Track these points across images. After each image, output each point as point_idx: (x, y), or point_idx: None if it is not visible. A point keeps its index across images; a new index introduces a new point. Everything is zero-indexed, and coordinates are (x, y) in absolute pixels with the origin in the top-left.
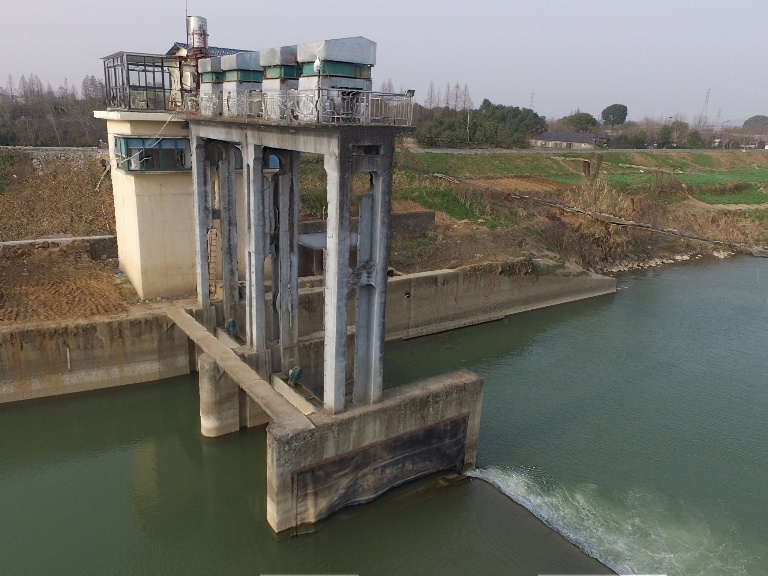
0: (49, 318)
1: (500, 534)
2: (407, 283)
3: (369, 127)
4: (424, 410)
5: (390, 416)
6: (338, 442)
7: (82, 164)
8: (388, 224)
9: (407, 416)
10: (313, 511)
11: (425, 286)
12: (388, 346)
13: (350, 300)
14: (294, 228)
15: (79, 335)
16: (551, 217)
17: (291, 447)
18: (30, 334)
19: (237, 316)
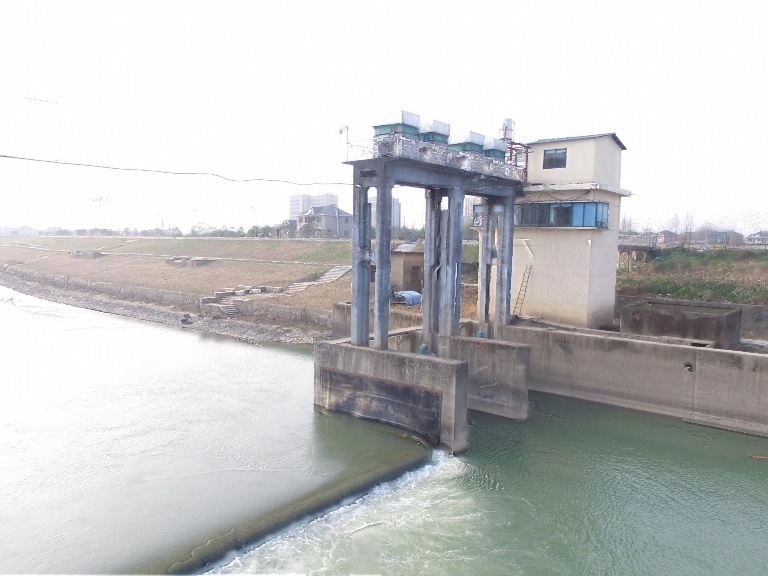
0: None
1: (364, 460)
2: (690, 353)
3: (369, 160)
4: (402, 368)
5: (377, 360)
6: (345, 361)
7: None
8: (382, 221)
9: (389, 366)
10: (328, 401)
11: (720, 364)
12: (659, 420)
13: (610, 352)
14: (450, 247)
15: (416, 322)
16: None
17: (321, 350)
18: (398, 315)
19: (503, 336)
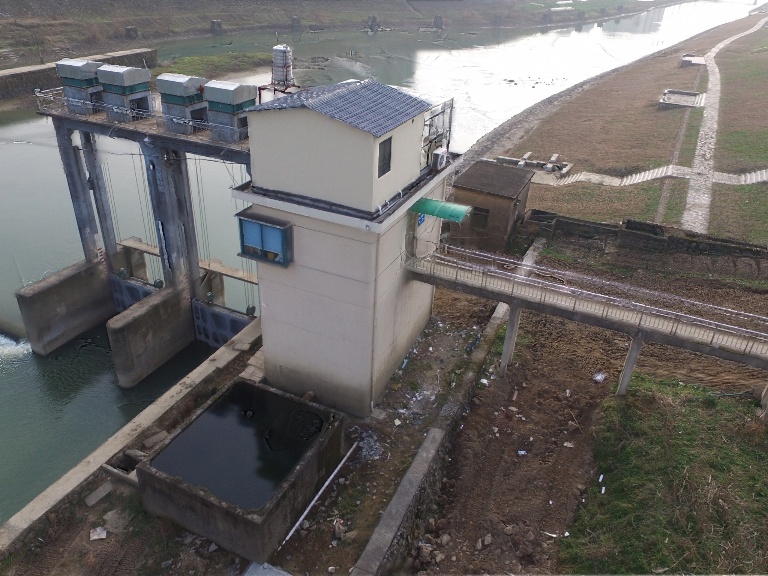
0: None
1: None
2: None
3: None
4: None
5: None
6: None
7: None
8: None
9: None
10: None
11: None
12: None
13: None
14: None
15: None
16: None
17: None
18: None
19: None
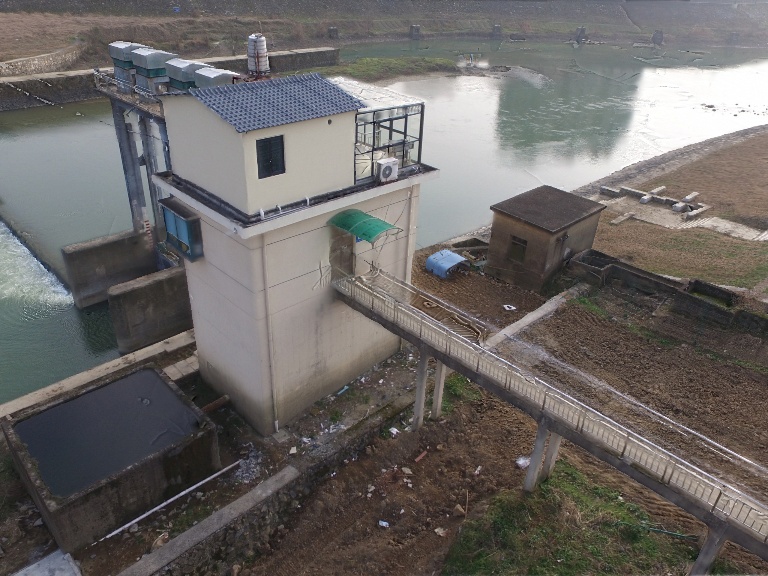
0: None
1: None
2: None
3: None
4: None
5: None
6: None
7: None
8: None
9: None
10: None
11: None
12: None
13: None
14: None
15: None
16: None
17: None
18: None
19: None
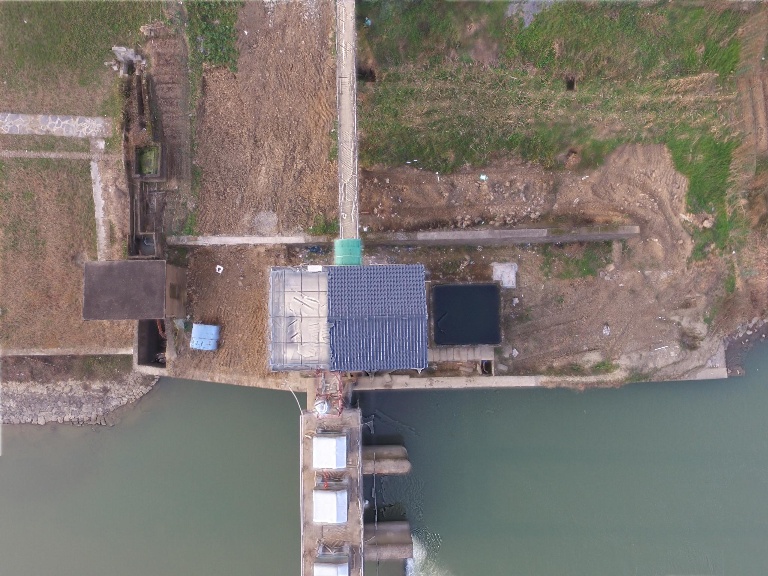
0: (246, 370)
1: None
2: None
3: None
4: None
5: None
6: None
7: (313, 4)
8: None
9: None
10: None
11: None
12: None
13: None
14: None
15: None
16: (752, 298)
17: None
18: None
19: None
